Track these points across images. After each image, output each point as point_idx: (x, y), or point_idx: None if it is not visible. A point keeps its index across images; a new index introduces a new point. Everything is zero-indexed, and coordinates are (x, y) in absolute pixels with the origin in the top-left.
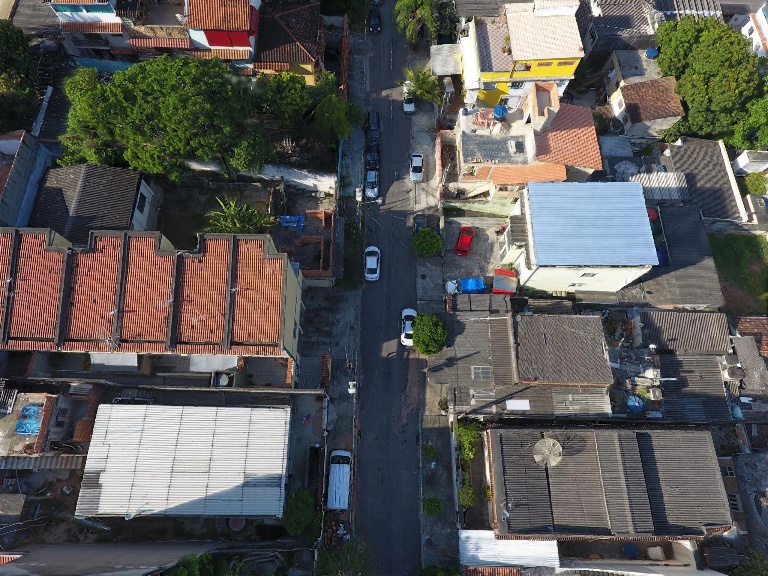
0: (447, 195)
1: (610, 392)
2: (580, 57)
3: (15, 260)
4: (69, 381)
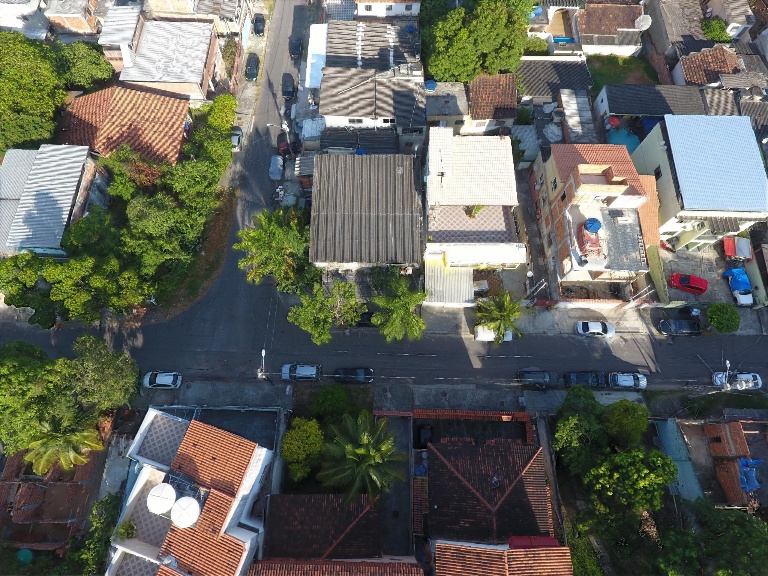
0: None
1: None
2: (510, 141)
3: None
4: None
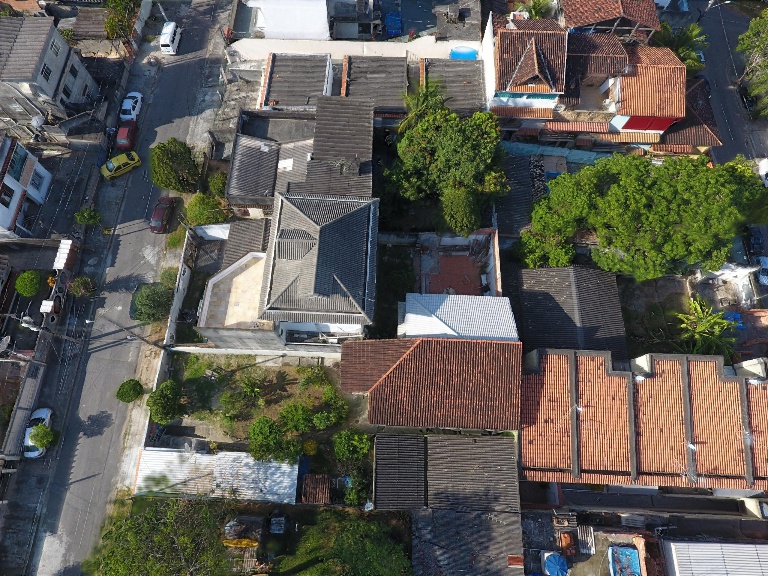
0: None
1: None
2: None
3: (576, 385)
4: None
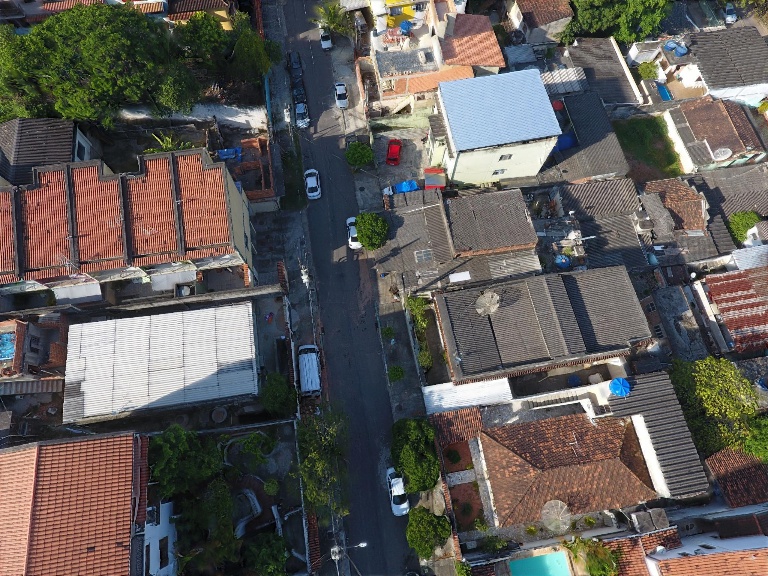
0: (373, 115)
1: (540, 256)
2: None
3: None
4: (37, 313)
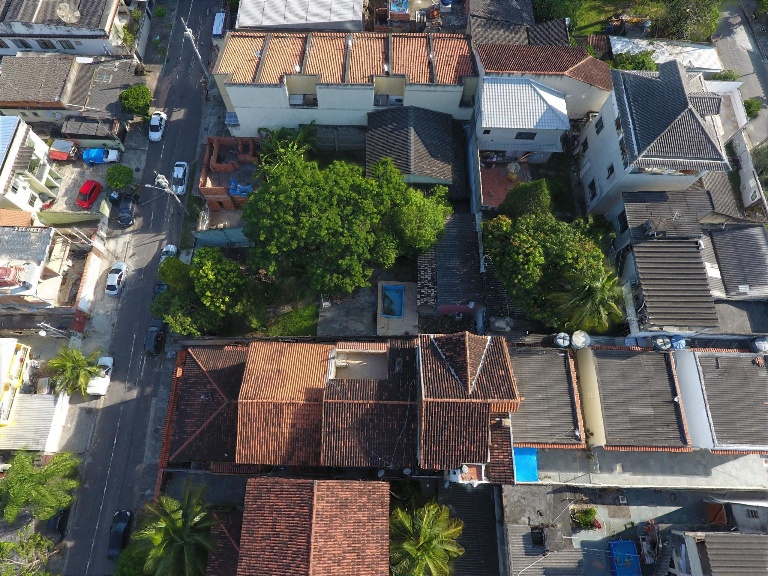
0: None
1: None
2: None
3: (431, 70)
4: None
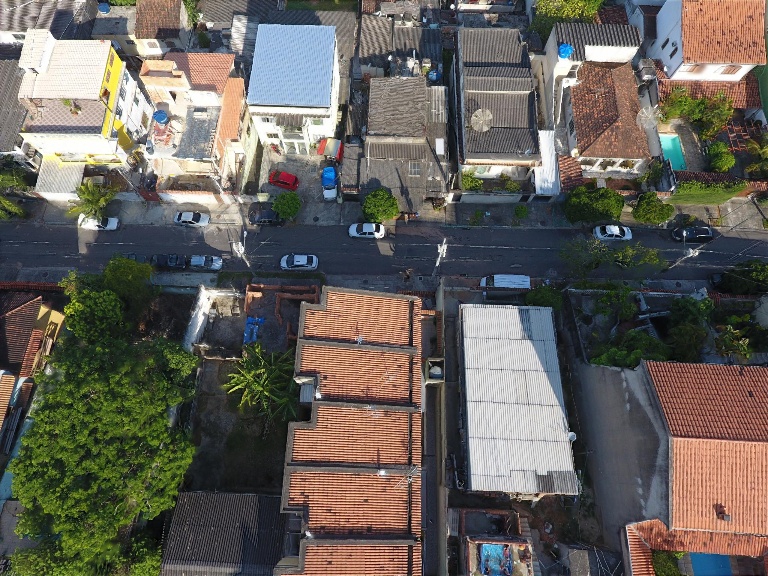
0: None
1: None
2: None
3: None
4: None
